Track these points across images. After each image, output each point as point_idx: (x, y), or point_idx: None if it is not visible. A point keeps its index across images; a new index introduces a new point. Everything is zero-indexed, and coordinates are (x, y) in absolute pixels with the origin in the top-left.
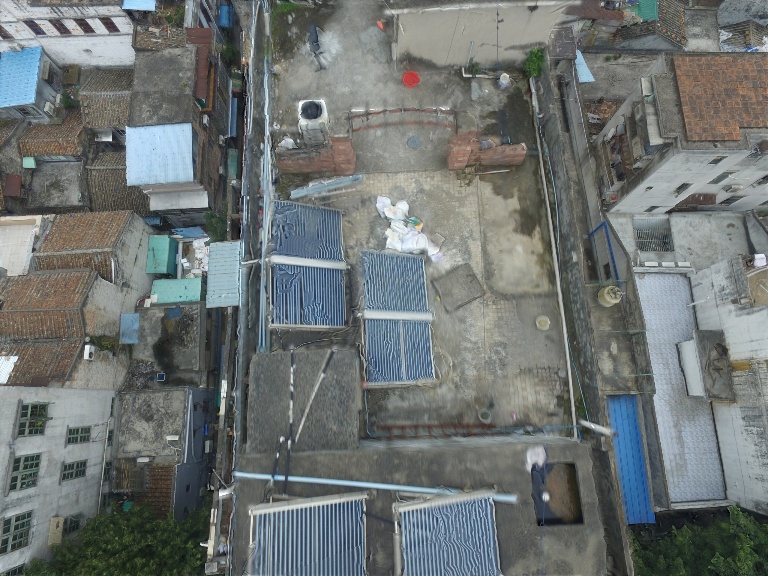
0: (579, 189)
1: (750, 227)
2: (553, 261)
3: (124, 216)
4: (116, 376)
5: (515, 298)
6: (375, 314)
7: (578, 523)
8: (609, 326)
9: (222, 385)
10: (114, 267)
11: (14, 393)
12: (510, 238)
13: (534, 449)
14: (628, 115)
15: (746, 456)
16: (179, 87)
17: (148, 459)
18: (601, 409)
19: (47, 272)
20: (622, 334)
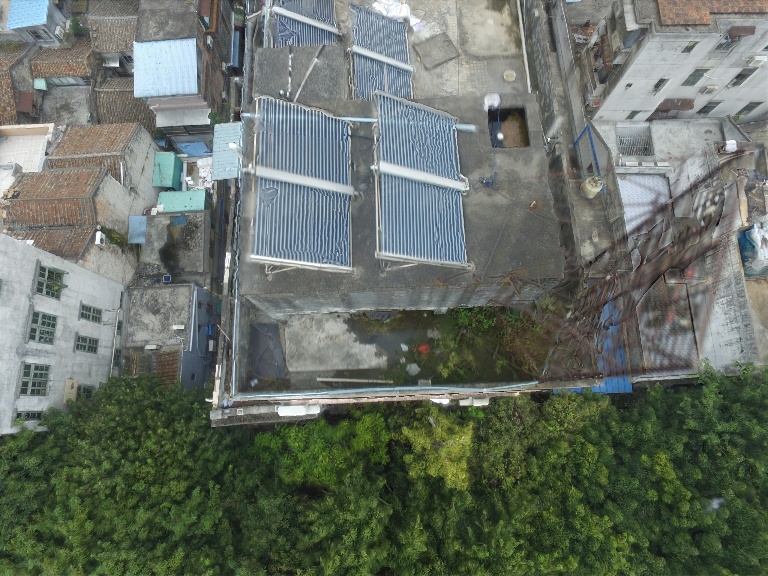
0: (565, 103)
1: (726, 131)
2: (520, 30)
3: (132, 127)
4: (125, 272)
5: (486, 59)
6: (362, 51)
7: (525, 146)
8: (591, 217)
9: (226, 257)
10: (123, 170)
11: (33, 252)
12: (483, 14)
13: (491, 95)
14: (609, 16)
15: (717, 327)
16: (184, 5)
17: (155, 346)
18: (556, 125)
19: (60, 170)
20: (603, 224)
